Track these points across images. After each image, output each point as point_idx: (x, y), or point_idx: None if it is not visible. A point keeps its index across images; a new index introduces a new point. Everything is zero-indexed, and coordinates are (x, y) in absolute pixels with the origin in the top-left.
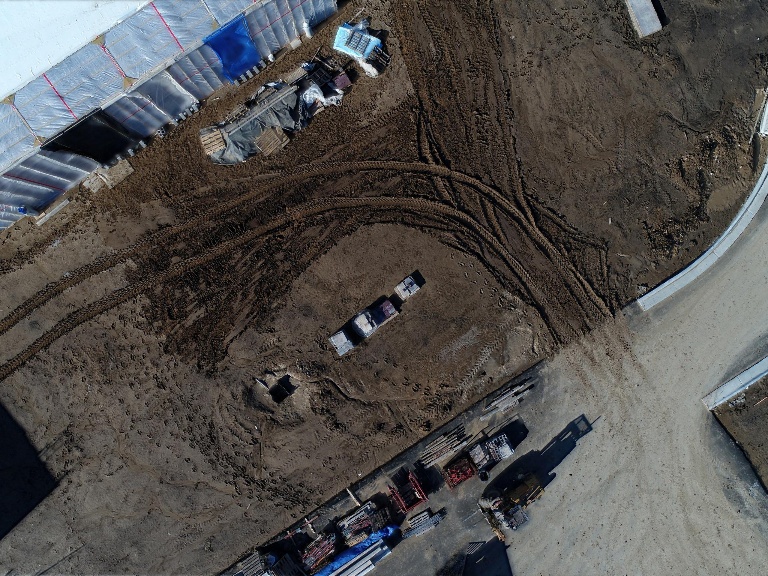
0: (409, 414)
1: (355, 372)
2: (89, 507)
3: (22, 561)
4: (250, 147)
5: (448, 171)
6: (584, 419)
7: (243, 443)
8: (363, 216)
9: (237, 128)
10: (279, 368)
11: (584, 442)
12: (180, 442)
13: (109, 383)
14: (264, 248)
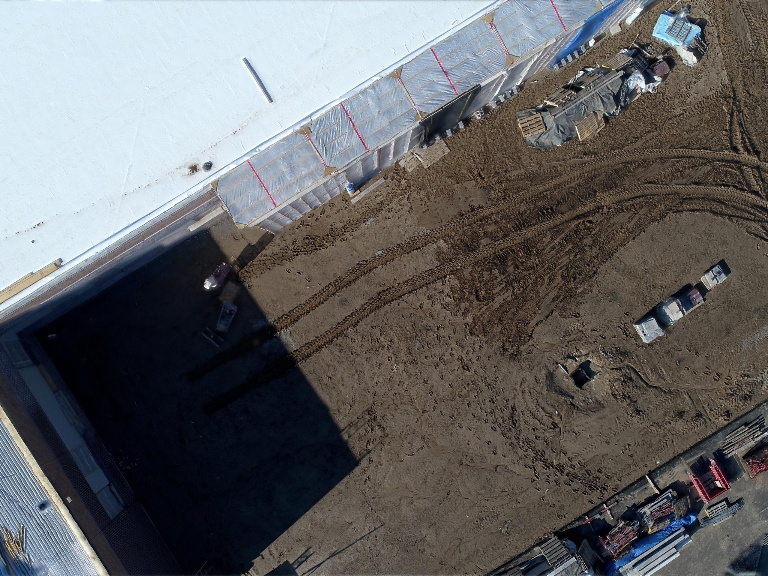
0: (709, 403)
1: (657, 360)
2: (389, 487)
3: (321, 539)
4: (570, 131)
5: (757, 162)
6: None
7: (544, 427)
8: (672, 204)
9: (563, 111)
10: (580, 353)
11: None
12: (482, 424)
13: (414, 363)
14: (573, 233)
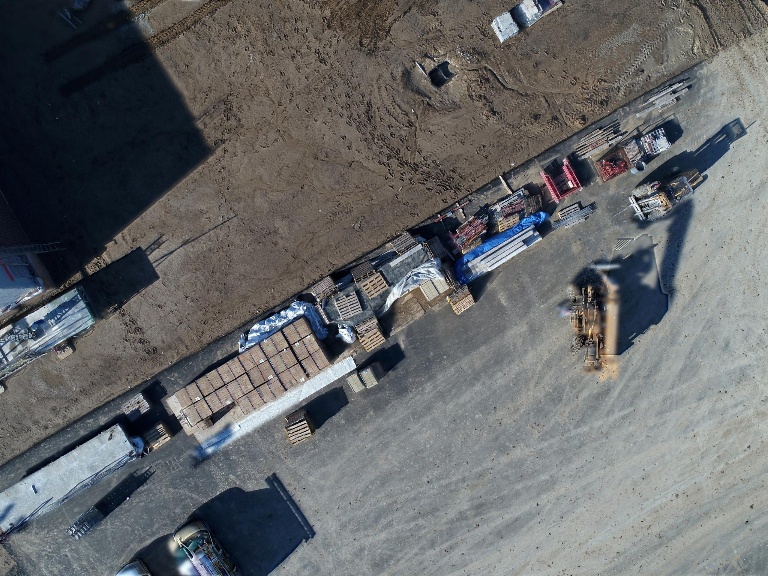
0: (565, 107)
1: (514, 62)
2: (243, 178)
3: (174, 227)
4: None
5: None
6: (739, 123)
7: (399, 125)
8: None
9: None
10: (439, 54)
11: (738, 145)
12: (337, 119)
13: (271, 54)
14: None
